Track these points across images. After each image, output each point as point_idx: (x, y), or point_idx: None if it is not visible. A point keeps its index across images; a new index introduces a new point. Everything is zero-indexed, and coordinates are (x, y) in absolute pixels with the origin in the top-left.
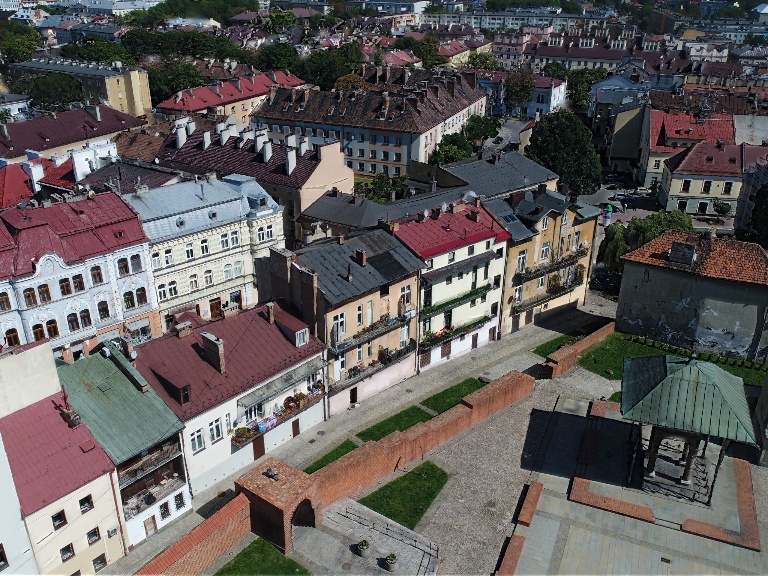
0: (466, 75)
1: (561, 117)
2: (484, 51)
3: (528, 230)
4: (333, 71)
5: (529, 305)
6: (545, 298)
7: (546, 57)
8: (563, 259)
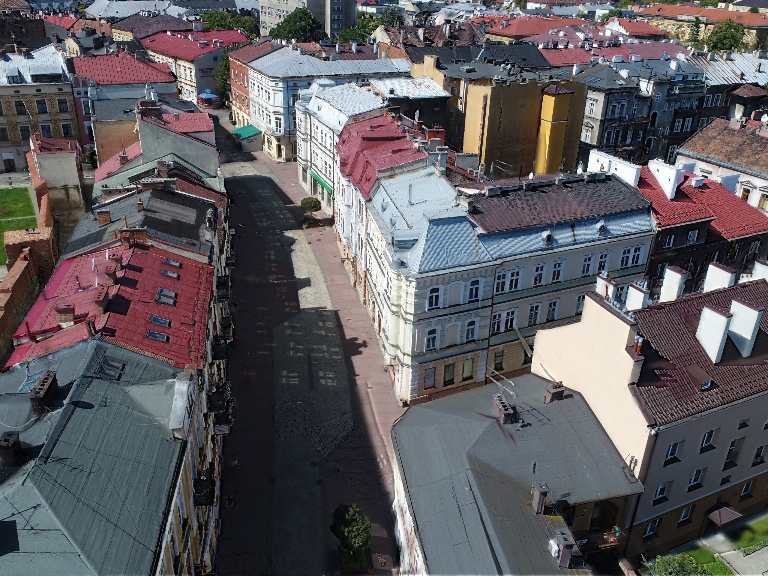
0: None
1: None
2: None
3: None
4: None
5: None
6: None
7: None
8: None
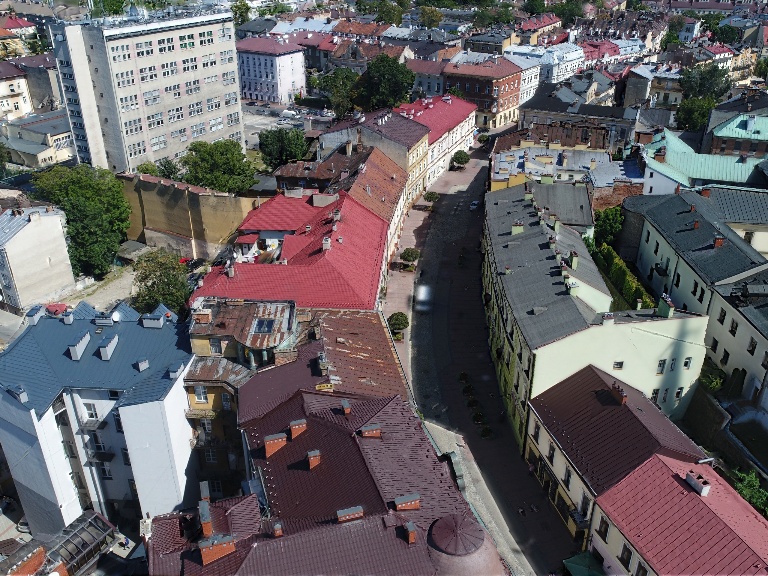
0: (659, 14)
1: (726, 28)
2: (636, 5)
3: (739, 52)
4: (572, 14)
5: (736, 79)
6: (740, 78)
7: (680, 8)
8: (747, 65)
